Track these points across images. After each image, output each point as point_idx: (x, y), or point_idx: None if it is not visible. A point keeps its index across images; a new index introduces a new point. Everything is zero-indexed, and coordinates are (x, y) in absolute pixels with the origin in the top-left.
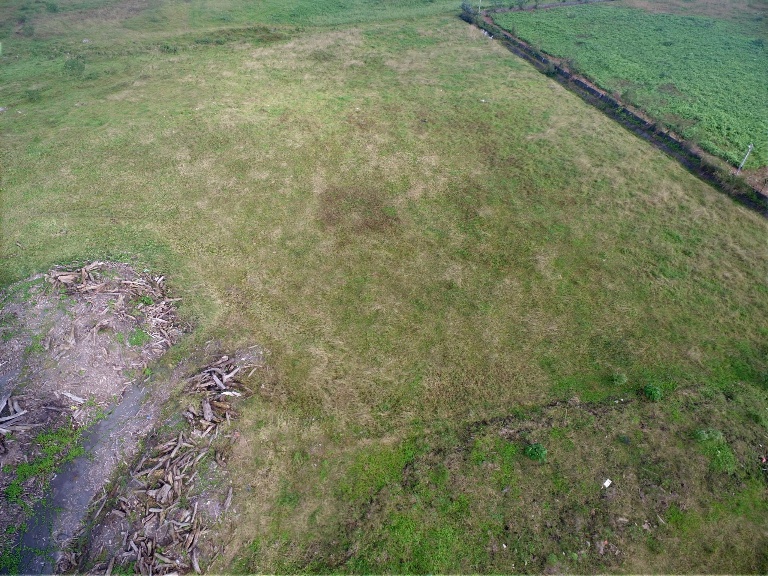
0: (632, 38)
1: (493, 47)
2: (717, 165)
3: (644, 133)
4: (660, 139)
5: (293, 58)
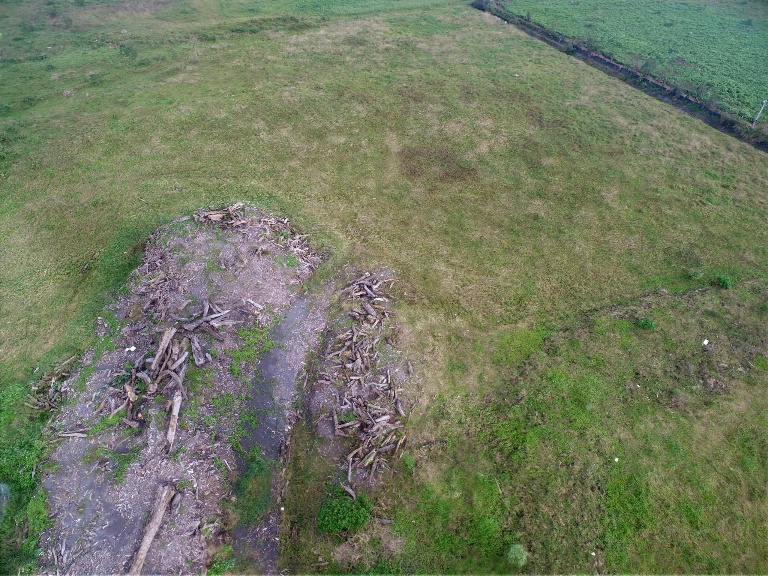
0: (635, 21)
1: (511, 31)
2: (736, 119)
3: (665, 98)
4: (680, 102)
5: (329, 43)
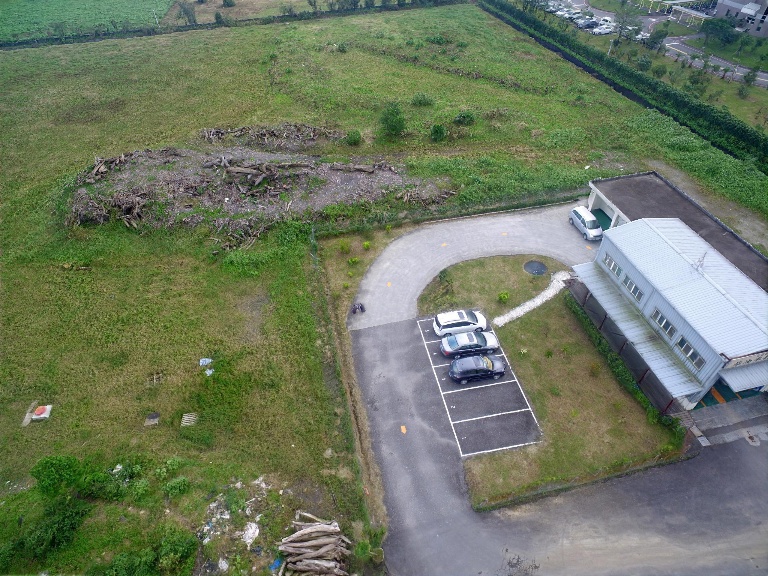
0: None
1: None
2: (152, 26)
3: (96, 40)
4: (108, 37)
5: None
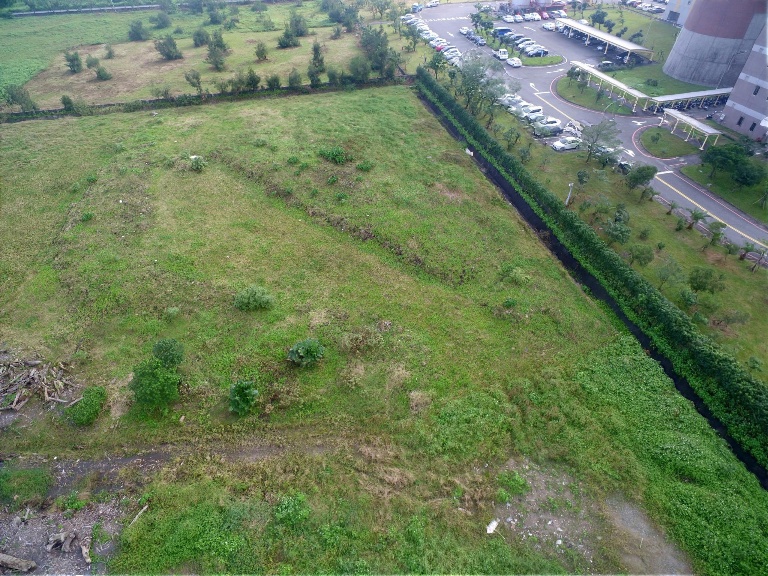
0: None
1: None
2: None
3: None
4: None
5: None
